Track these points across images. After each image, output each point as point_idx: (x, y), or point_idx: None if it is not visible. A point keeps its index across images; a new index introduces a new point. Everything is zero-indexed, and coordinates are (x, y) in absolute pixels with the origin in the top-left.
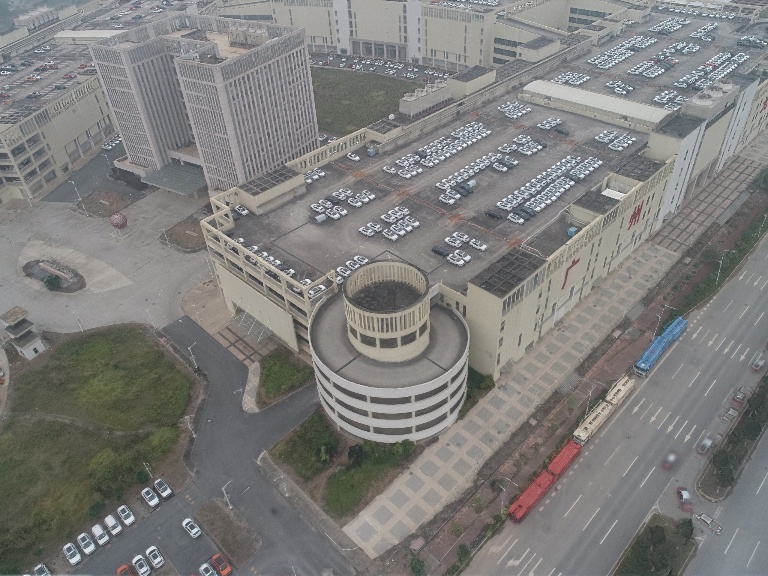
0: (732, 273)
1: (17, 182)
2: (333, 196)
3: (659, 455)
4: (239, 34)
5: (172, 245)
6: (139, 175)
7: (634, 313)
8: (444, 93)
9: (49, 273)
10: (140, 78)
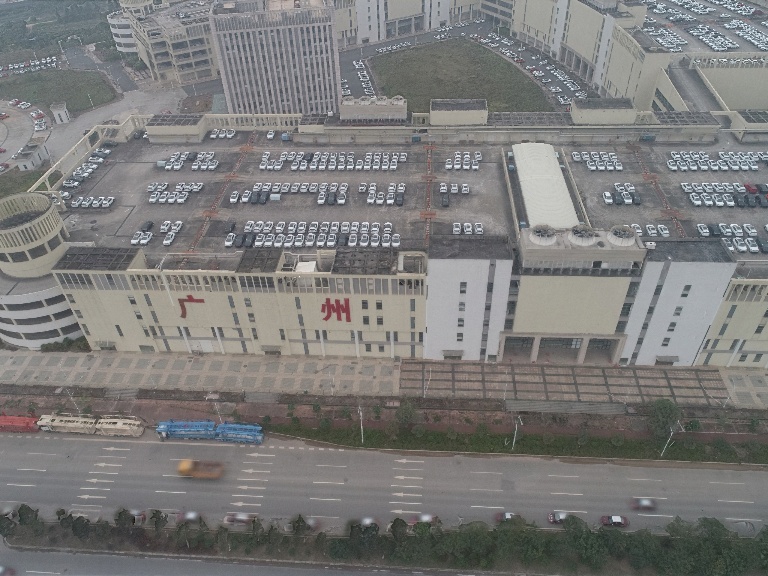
0: (406, 450)
1: None
2: None
3: (52, 484)
4: None
5: None
6: None
7: (257, 397)
8: (394, 111)
9: None
10: None
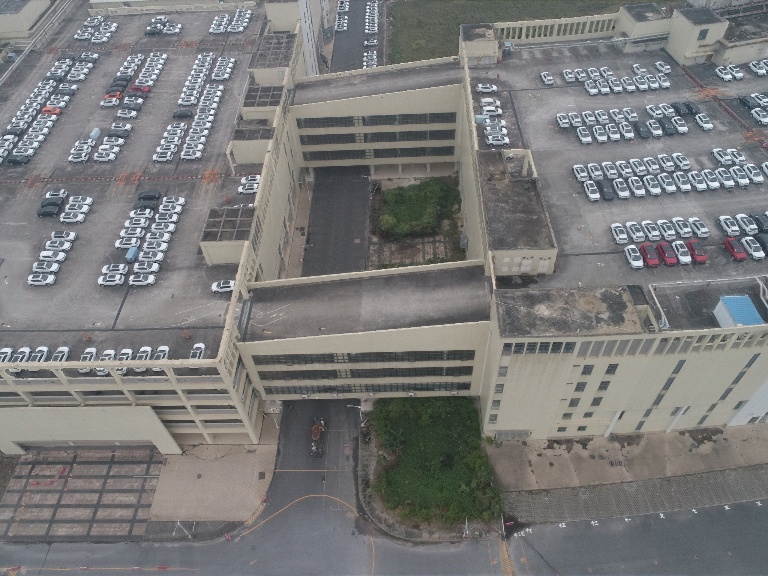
0: None
1: None
2: None
3: None
4: None
5: None
6: None
7: None
8: None
9: None
10: None
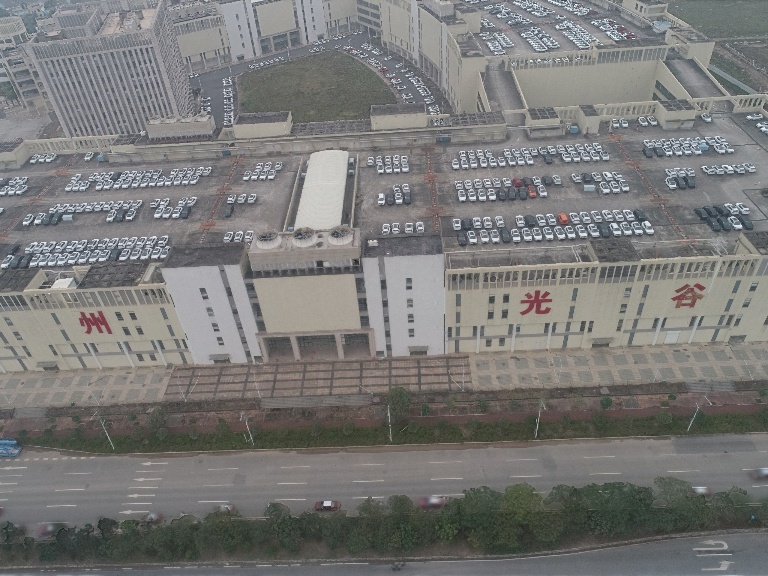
0: (154, 453)
1: (43, 95)
2: None
3: None
4: None
5: None
6: None
7: (26, 412)
8: (199, 127)
9: None
10: None
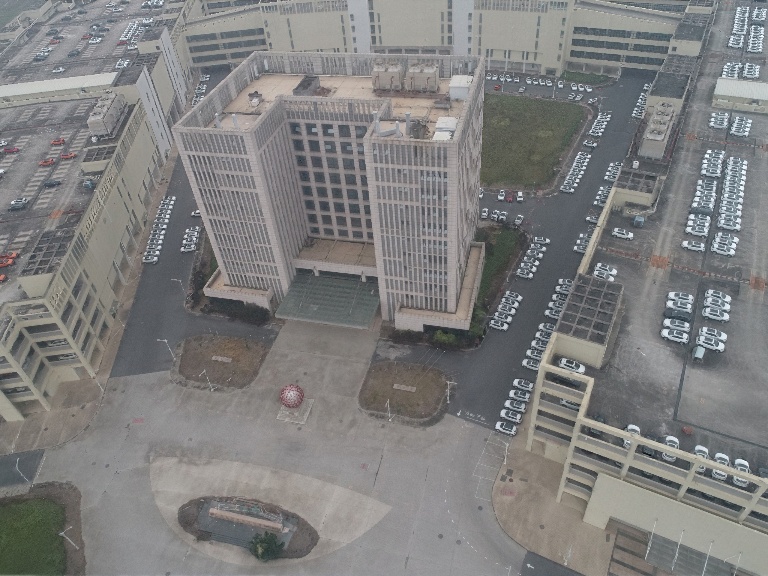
0: None
1: (68, 359)
2: (674, 309)
3: None
4: (393, 77)
5: (393, 416)
6: (254, 303)
7: None
8: None
9: (237, 524)
10: (266, 168)
